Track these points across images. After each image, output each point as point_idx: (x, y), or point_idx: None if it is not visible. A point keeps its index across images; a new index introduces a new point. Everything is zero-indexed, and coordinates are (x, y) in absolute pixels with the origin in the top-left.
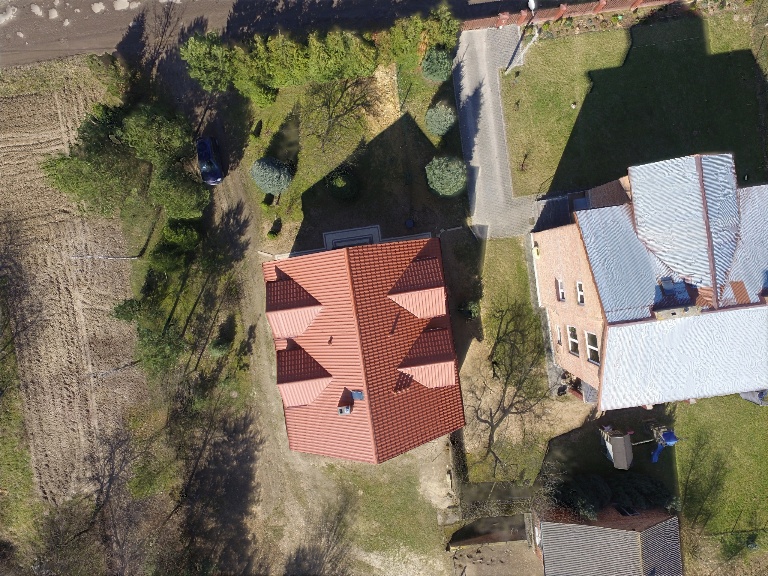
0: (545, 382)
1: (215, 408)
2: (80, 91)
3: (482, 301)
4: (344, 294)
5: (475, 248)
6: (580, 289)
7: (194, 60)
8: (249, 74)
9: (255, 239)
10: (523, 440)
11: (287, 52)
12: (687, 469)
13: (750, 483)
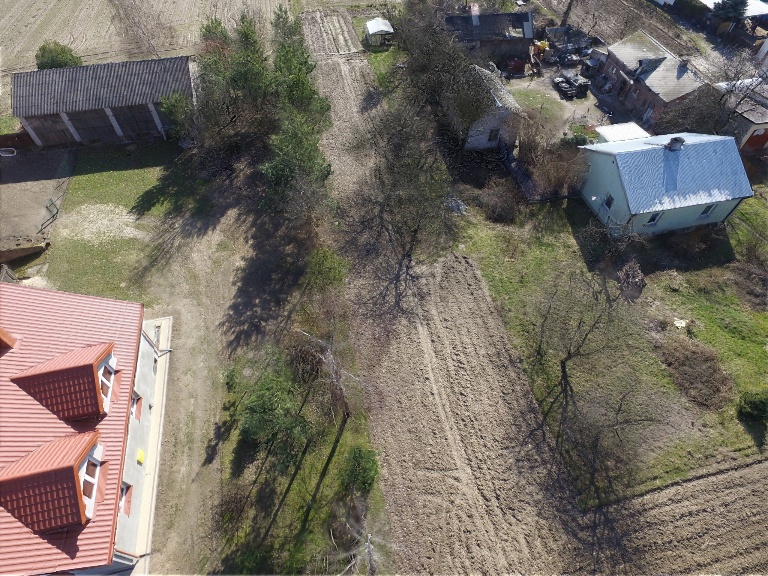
0: None
1: None
2: None
3: None
4: None
5: None
6: None
7: None
8: None
9: None
10: None
11: None
12: None
13: None
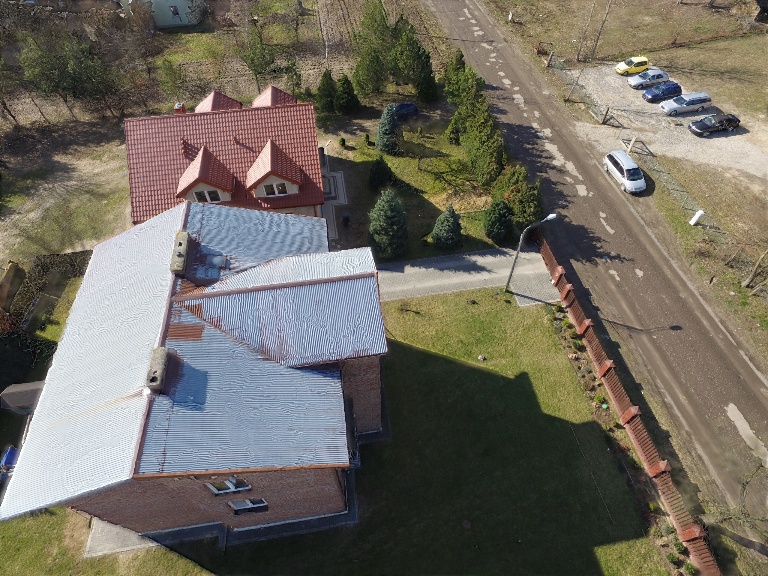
0: None
1: None
2: None
3: None
4: None
5: None
6: None
7: None
8: None
9: None
10: None
11: None
12: None
13: None
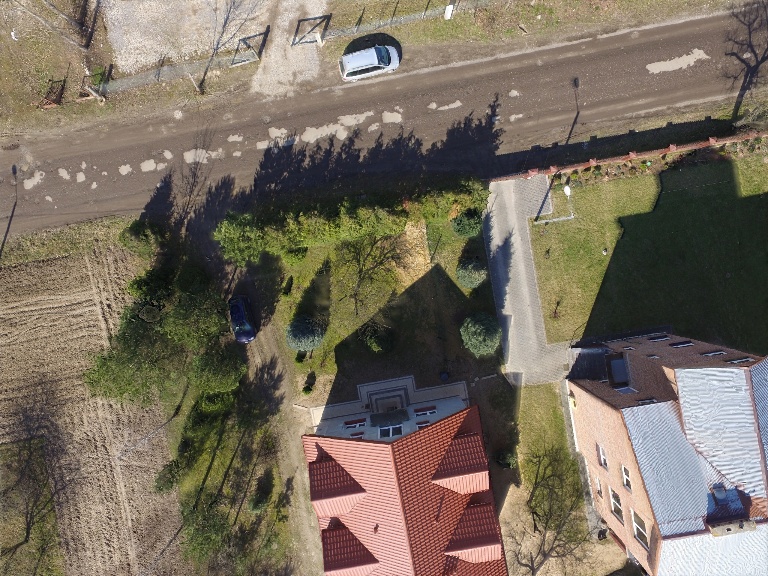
0: (585, 526)
1: (255, 560)
2: (110, 253)
3: (519, 447)
4: (390, 488)
5: (510, 395)
6: (626, 473)
7: (228, 241)
8: (281, 243)
9: (290, 393)
10: None
11: (319, 226)
12: None
13: None
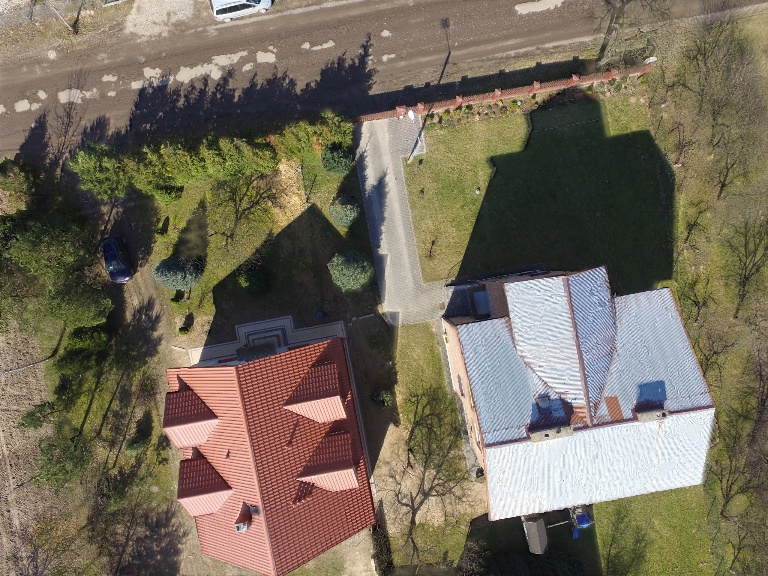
0: (463, 464)
1: (136, 504)
2: None
3: (397, 386)
4: (236, 411)
5: (388, 335)
6: None
7: (86, 172)
8: (147, 179)
9: (168, 334)
10: (445, 522)
11: (181, 159)
12: (608, 543)
13: (671, 553)
